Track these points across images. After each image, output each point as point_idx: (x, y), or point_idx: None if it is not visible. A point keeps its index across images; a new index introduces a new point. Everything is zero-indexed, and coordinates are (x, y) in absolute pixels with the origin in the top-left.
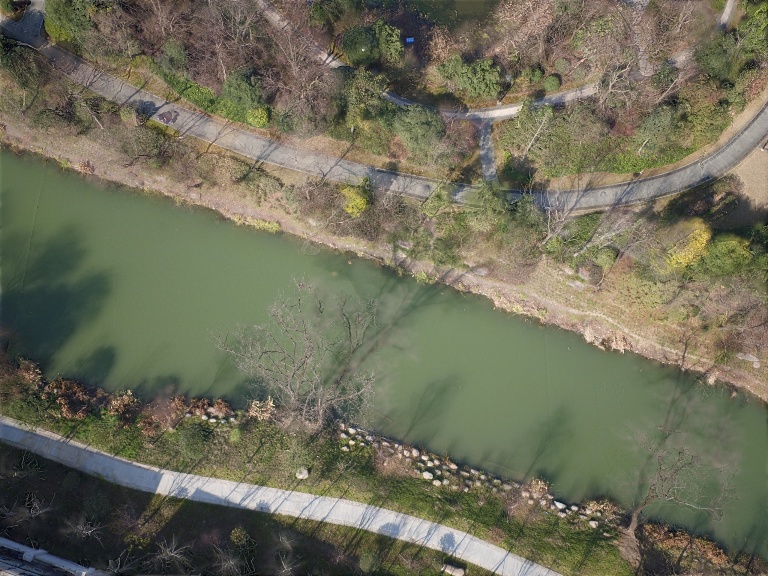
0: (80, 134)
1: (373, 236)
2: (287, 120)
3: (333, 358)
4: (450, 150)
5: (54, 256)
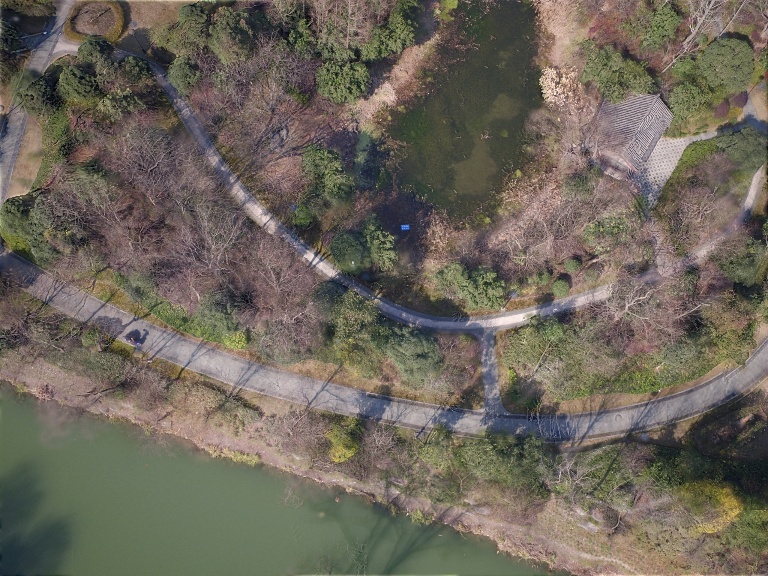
0: (38, 357)
1: (363, 475)
2: (267, 351)
3: None
4: (449, 373)
5: (6, 502)
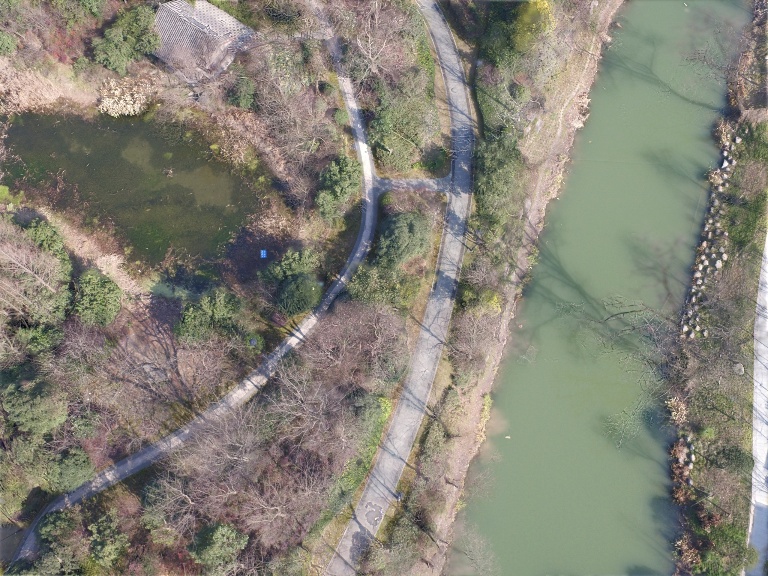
0: None
1: (504, 298)
2: (400, 371)
3: (619, 344)
4: None
5: None
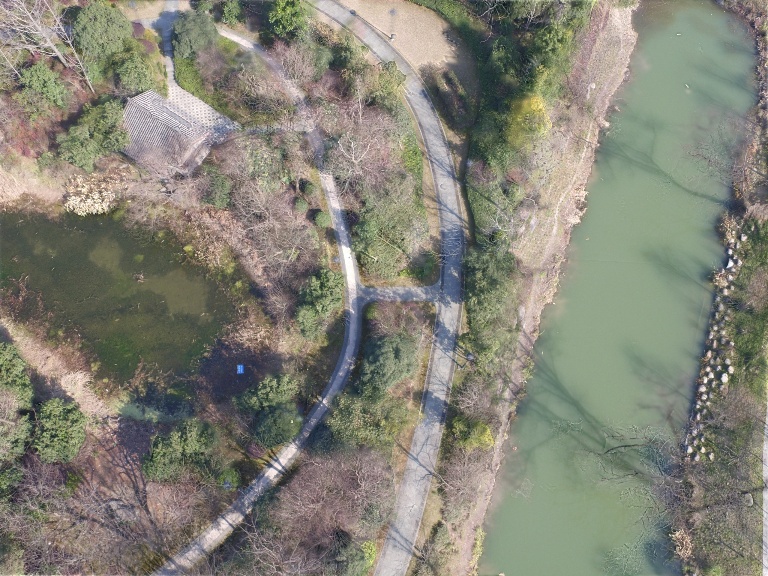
0: None
1: (497, 421)
2: (386, 515)
3: (619, 468)
4: None
5: None
